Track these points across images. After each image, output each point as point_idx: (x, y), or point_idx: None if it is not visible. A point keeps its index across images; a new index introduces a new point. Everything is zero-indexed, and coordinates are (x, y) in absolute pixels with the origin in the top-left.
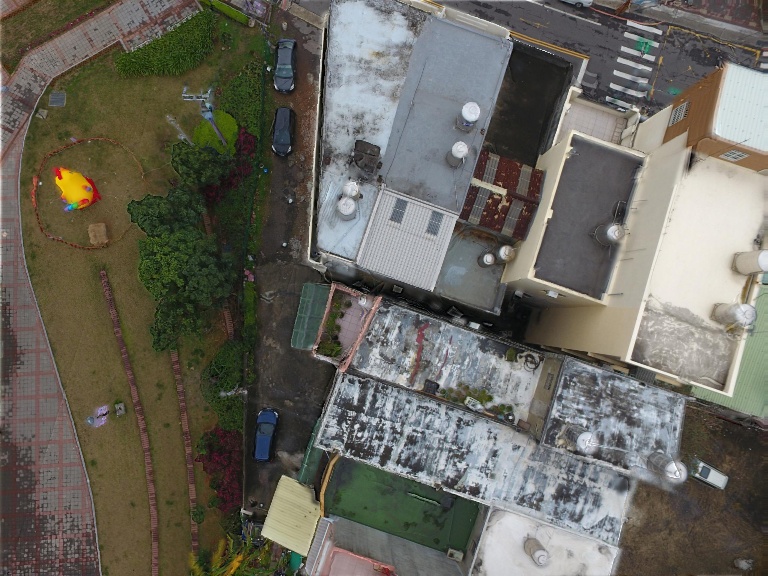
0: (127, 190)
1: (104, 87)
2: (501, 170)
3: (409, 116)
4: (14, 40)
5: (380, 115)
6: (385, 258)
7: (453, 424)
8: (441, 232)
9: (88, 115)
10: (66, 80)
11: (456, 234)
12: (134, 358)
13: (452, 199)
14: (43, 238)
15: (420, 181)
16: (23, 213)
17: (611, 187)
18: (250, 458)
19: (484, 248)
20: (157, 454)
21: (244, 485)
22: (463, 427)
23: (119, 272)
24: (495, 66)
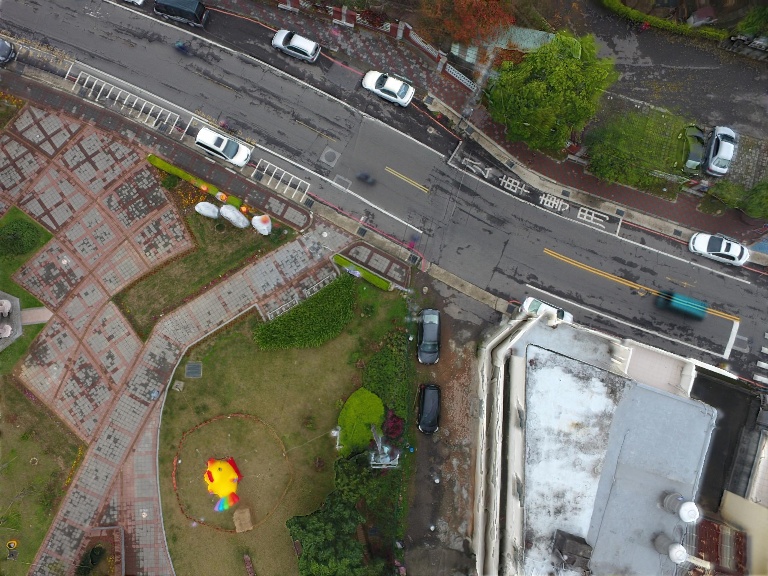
0: (269, 469)
1: (243, 360)
2: (700, 536)
3: (611, 493)
4: (147, 305)
5: (581, 492)
6: None
7: None
8: None
9: (227, 389)
10: (202, 350)
11: None
12: None
13: None
14: (184, 519)
15: (625, 565)
16: (162, 493)
17: None
18: None
19: None
20: None
21: None
22: None
23: (263, 557)
24: (698, 435)
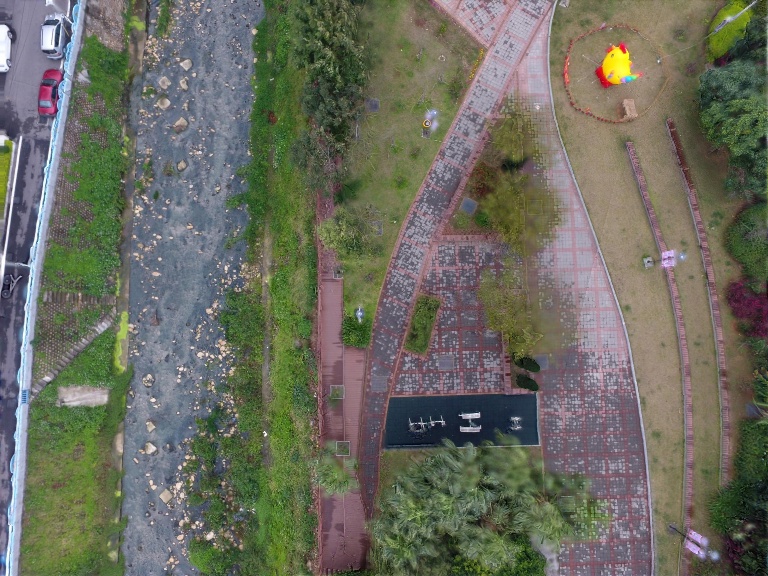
0: (645, 72)
1: None
2: None
3: None
4: None
5: None
6: None
7: None
8: None
9: (609, 5)
10: None
11: None
12: (660, 218)
13: None
14: (573, 112)
15: None
16: (554, 89)
17: None
18: None
19: None
20: (684, 302)
21: None
22: None
23: (643, 143)
24: None
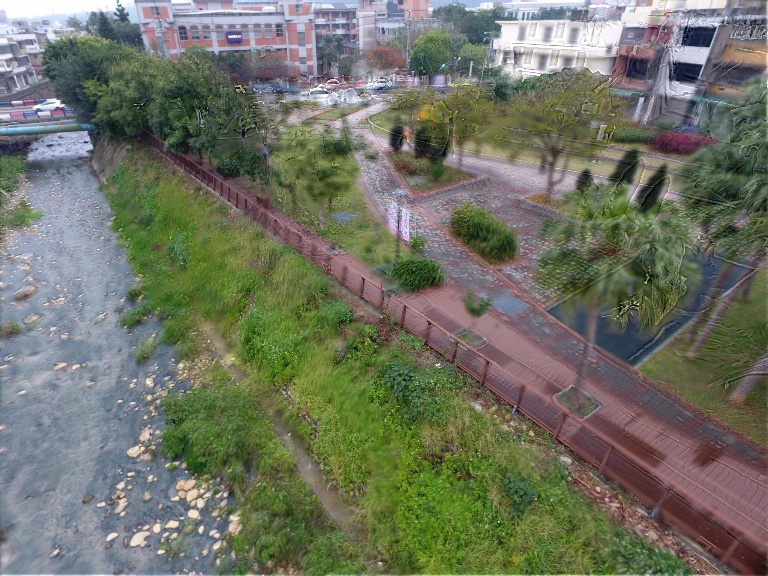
0: None
1: None
2: None
3: None
4: None
5: None
6: None
7: None
8: None
9: None
10: None
11: None
12: None
13: None
14: None
15: None
16: (414, 138)
17: None
18: None
19: None
20: None
21: None
22: None
23: None
24: None
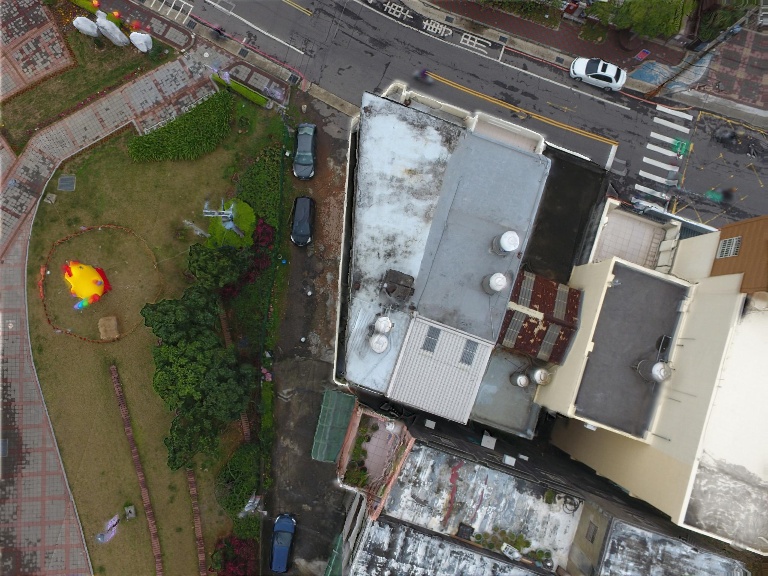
0: (139, 280)
1: (116, 172)
2: (537, 291)
3: (442, 238)
4: (22, 120)
5: (412, 237)
6: (417, 388)
7: (489, 571)
8: (475, 361)
9: (99, 201)
10: (76, 163)
11: (490, 359)
12: (145, 458)
13: (487, 327)
14: (51, 330)
15: (454, 308)
16: (30, 303)
17: (655, 319)
18: (266, 566)
19: (517, 368)
20: (169, 560)
21: None
22: (499, 574)
23: (130, 367)
24: (532, 184)
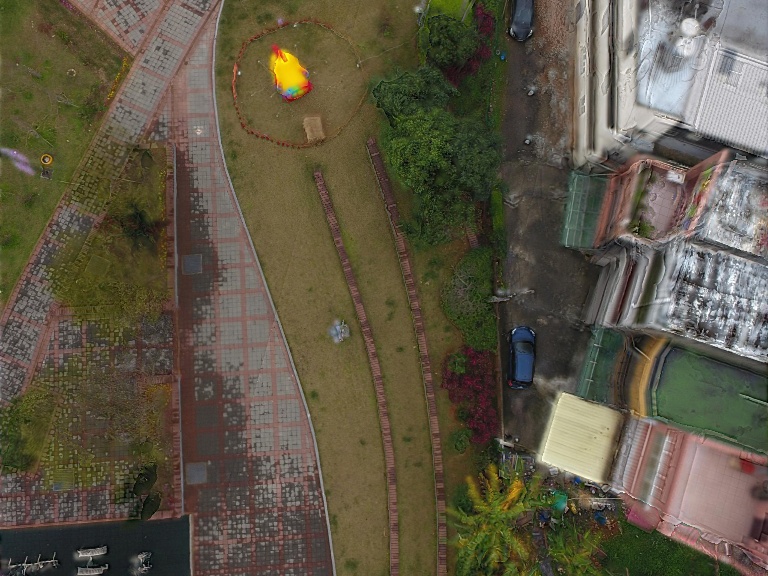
0: (341, 81)
1: None
2: None
3: None
4: None
5: None
6: (720, 125)
7: None
8: None
9: None
10: None
11: None
12: (358, 272)
13: None
14: (244, 136)
15: (757, 41)
16: (219, 107)
17: None
18: None
19: None
20: (389, 383)
21: (503, 413)
22: None
23: (336, 174)
24: None
